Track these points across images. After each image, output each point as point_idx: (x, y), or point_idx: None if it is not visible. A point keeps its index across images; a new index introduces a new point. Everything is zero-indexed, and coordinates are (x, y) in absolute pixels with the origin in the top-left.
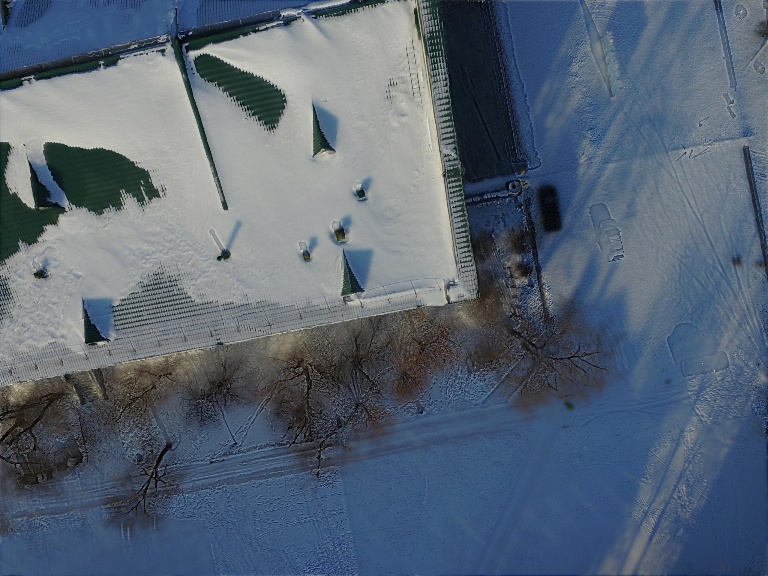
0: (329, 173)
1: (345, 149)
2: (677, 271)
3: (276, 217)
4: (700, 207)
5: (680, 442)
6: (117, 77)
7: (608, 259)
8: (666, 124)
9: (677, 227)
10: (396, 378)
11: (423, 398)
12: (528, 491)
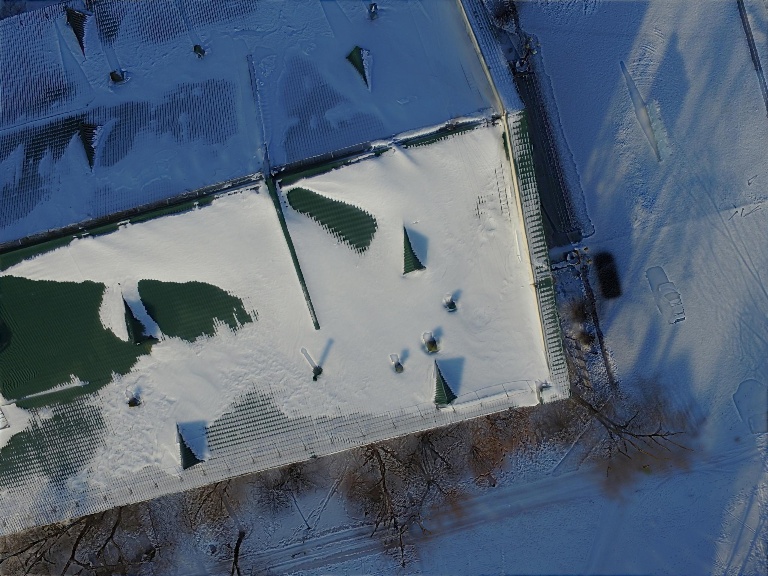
0: (419, 288)
1: (435, 265)
2: (737, 329)
3: (367, 332)
4: (755, 264)
5: (754, 499)
6: (212, 216)
7: (669, 322)
8: (715, 185)
9: (734, 285)
10: (466, 452)
11: (494, 471)
12: (605, 557)
